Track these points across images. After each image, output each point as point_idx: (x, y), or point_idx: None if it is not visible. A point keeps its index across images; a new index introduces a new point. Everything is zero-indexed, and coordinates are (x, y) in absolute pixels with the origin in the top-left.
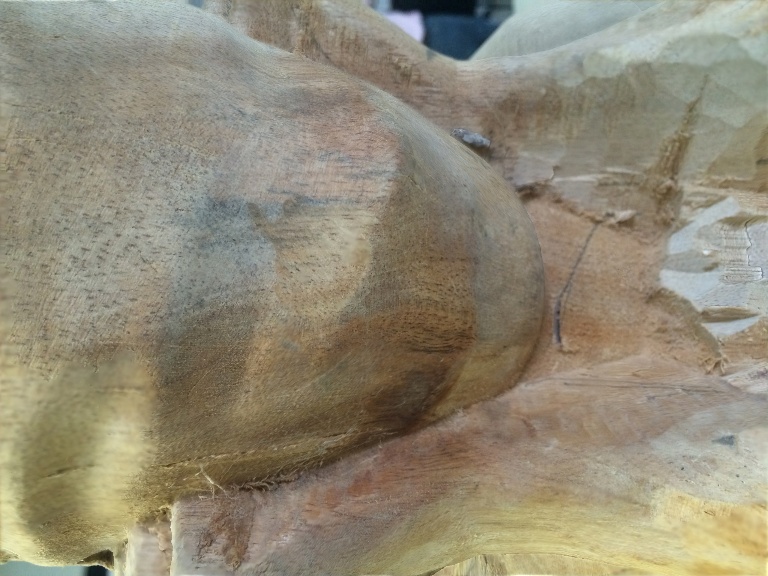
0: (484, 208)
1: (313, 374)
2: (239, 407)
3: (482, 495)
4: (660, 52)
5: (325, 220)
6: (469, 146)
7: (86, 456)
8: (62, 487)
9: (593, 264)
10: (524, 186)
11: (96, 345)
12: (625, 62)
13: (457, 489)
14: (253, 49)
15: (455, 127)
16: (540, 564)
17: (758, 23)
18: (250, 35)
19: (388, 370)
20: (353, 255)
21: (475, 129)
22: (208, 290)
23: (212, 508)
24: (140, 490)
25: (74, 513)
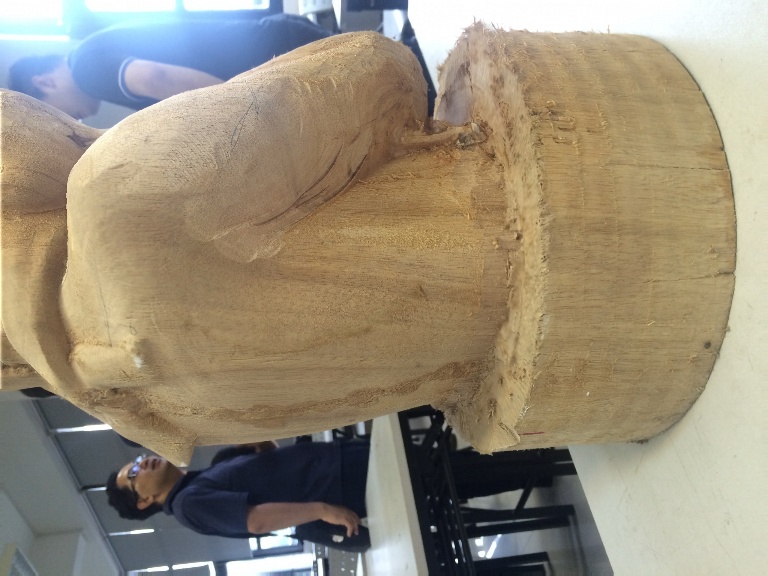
0: None
1: None
2: None
3: None
4: None
5: None
6: None
7: None
8: None
9: None
10: None
11: None
12: None
13: None
14: None
15: None
16: None
17: None
18: None
19: None
20: None
21: None
22: None
23: None
24: None
25: None
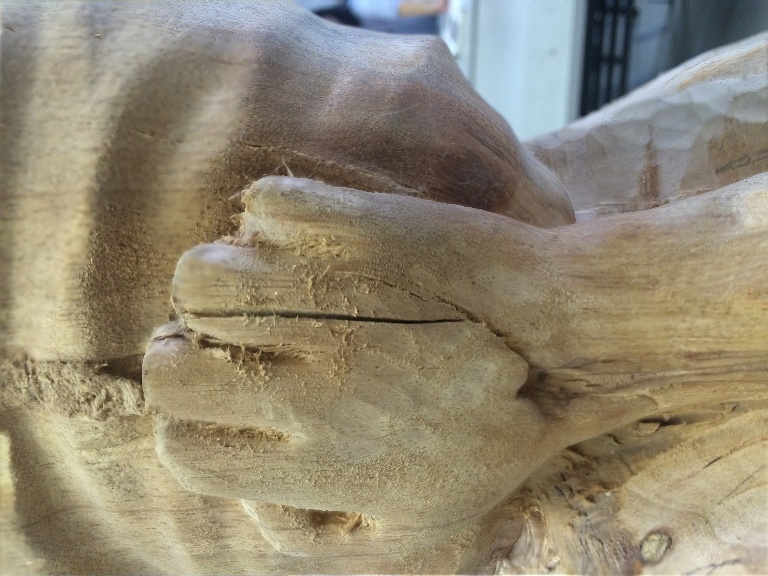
0: None
1: (387, 108)
2: (323, 115)
3: (563, 243)
4: (610, 119)
5: (390, 43)
6: None
7: (180, 128)
8: (146, 161)
9: None
10: None
11: (218, 29)
12: (588, 129)
13: (536, 232)
14: None
15: None
16: (670, 504)
17: (670, 91)
18: None
19: (450, 137)
20: (413, 55)
21: None
22: (305, 39)
23: None
24: (220, 176)
25: (142, 212)
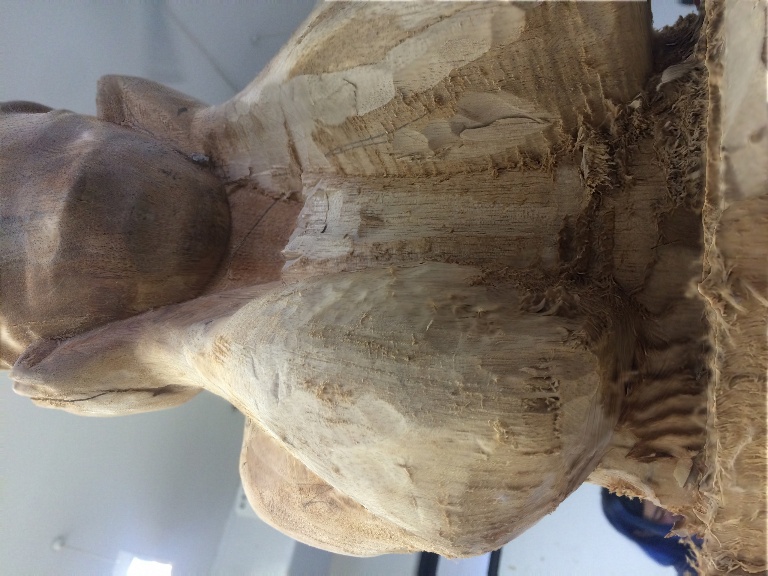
0: (149, 204)
1: (51, 288)
2: (29, 302)
3: (140, 348)
4: (259, 97)
5: (43, 221)
6: (196, 163)
7: None
8: None
9: (265, 226)
10: (227, 182)
11: None
12: (249, 104)
13: (128, 345)
14: (61, 137)
15: (193, 152)
16: None
17: (285, 75)
18: (104, 117)
19: (87, 287)
20: (53, 236)
21: (202, 152)
22: (4, 253)
23: (36, 345)
24: (14, 336)
25: (5, 345)
